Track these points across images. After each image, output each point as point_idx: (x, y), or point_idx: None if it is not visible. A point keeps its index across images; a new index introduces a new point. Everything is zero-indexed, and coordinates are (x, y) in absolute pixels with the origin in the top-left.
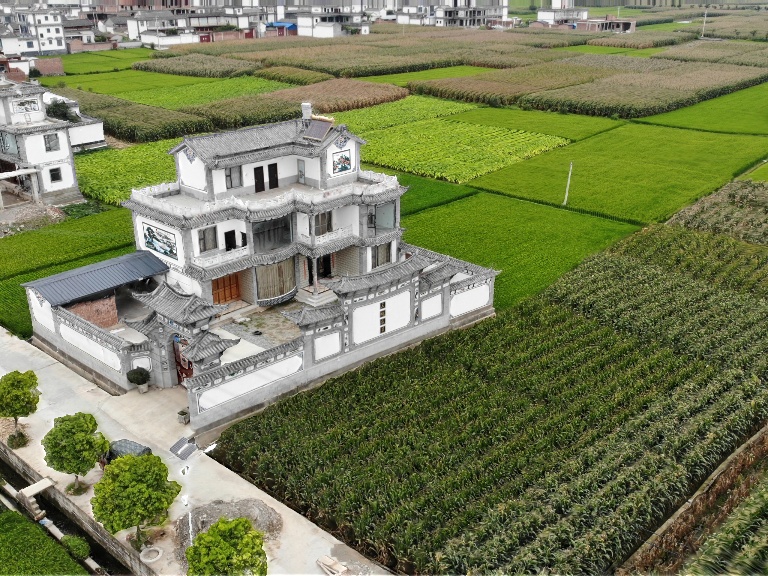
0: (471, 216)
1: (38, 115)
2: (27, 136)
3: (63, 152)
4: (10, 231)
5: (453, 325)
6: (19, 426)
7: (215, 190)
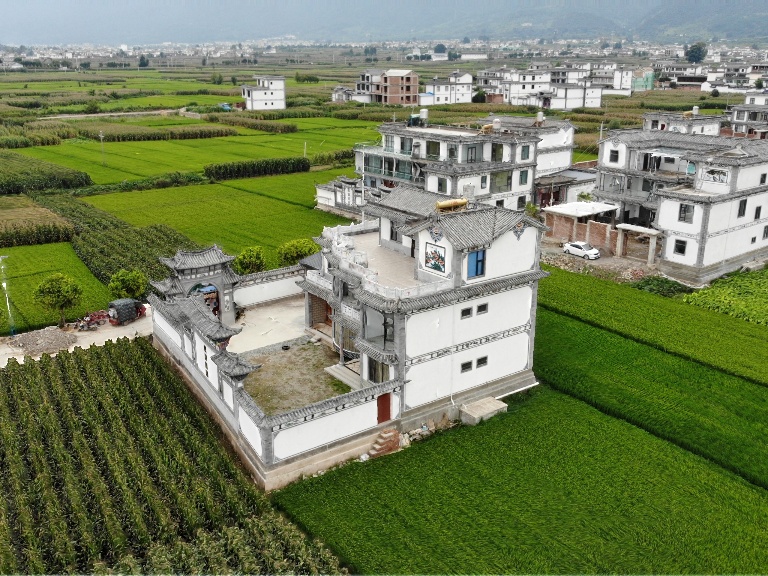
0: (763, 549)
1: (724, 188)
2: (665, 199)
3: (694, 227)
4: (582, 270)
5: (240, 440)
6: (214, 297)
7: (382, 234)
